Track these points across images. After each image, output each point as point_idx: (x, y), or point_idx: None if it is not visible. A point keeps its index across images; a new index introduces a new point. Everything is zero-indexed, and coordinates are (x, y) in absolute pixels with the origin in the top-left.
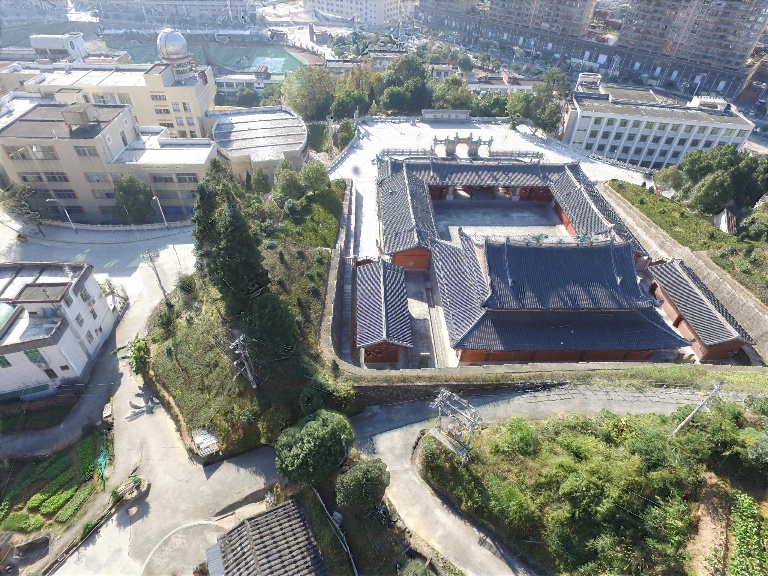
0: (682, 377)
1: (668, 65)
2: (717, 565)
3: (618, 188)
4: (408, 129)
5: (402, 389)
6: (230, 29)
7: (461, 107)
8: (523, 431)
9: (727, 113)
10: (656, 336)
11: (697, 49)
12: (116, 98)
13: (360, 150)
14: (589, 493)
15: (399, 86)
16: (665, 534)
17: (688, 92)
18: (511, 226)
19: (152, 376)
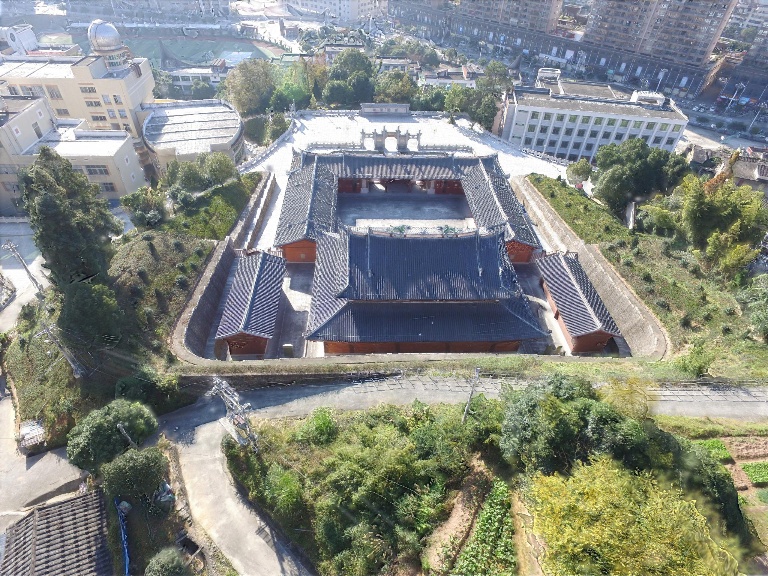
0: (510, 367)
1: (632, 61)
2: (450, 552)
3: (535, 182)
4: (345, 123)
5: (233, 379)
6: (200, 23)
7: (403, 101)
8: (319, 420)
9: (665, 108)
10: (516, 327)
11: (660, 45)
12: (45, 90)
13: (291, 143)
14: (352, 481)
15: (344, 80)
16: (412, 521)
17: (647, 88)
18: (420, 219)
19: (6, 367)
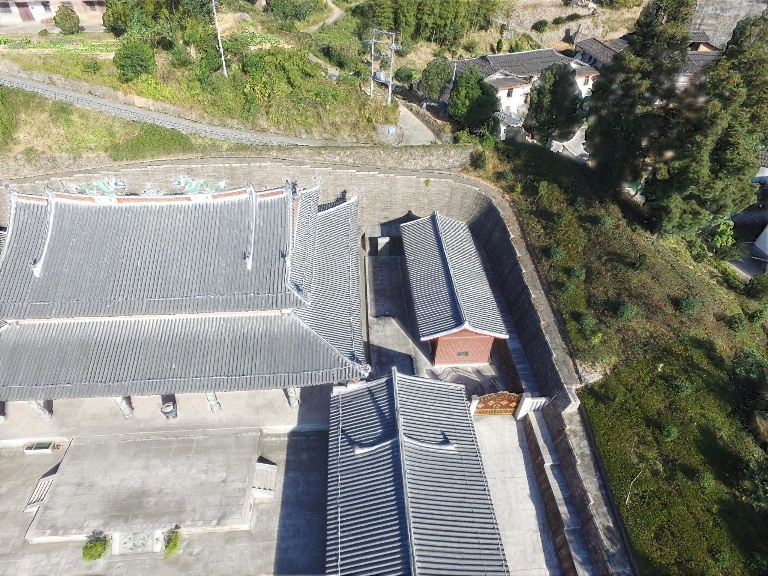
0: (152, 126)
1: None
2: None
3: None
4: None
5: None
6: None
7: None
8: (328, 88)
9: None
10: None
11: None
12: None
13: None
14: None
15: None
16: None
17: None
18: None
19: None
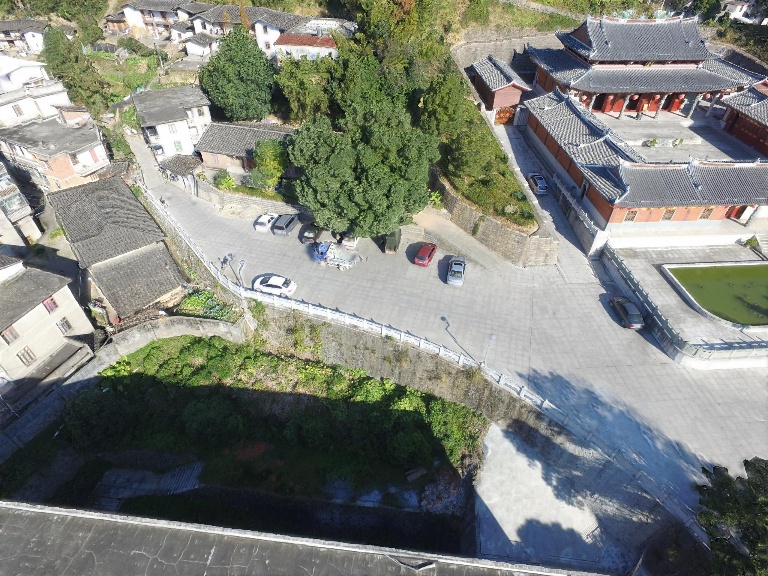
0: (557, 14)
1: None
2: None
3: None
4: None
5: None
6: None
7: None
8: None
9: None
10: None
11: None
12: None
13: None
14: None
15: None
16: None
17: None
18: None
19: None
